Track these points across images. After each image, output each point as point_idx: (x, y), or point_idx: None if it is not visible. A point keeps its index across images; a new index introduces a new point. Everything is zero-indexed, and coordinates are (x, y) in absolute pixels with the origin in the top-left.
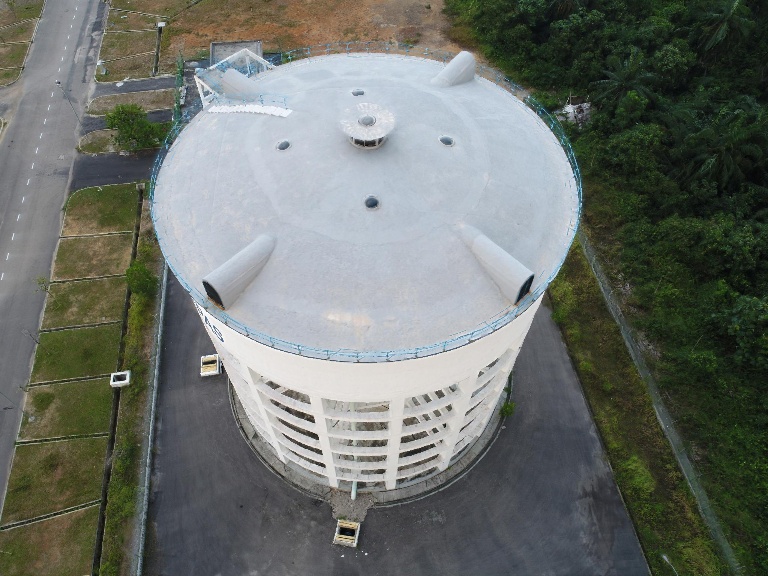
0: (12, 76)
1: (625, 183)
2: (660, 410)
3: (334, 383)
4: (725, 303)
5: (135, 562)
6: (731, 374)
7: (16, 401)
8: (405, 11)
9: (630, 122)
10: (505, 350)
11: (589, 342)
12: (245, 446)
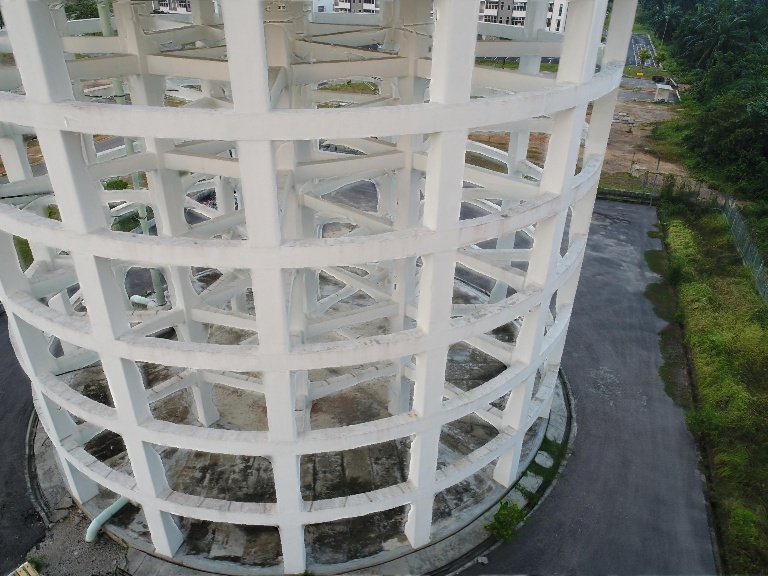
0: None
1: None
2: None
3: None
4: None
5: None
6: None
7: None
8: None
9: None
10: None
11: (767, 498)
12: None
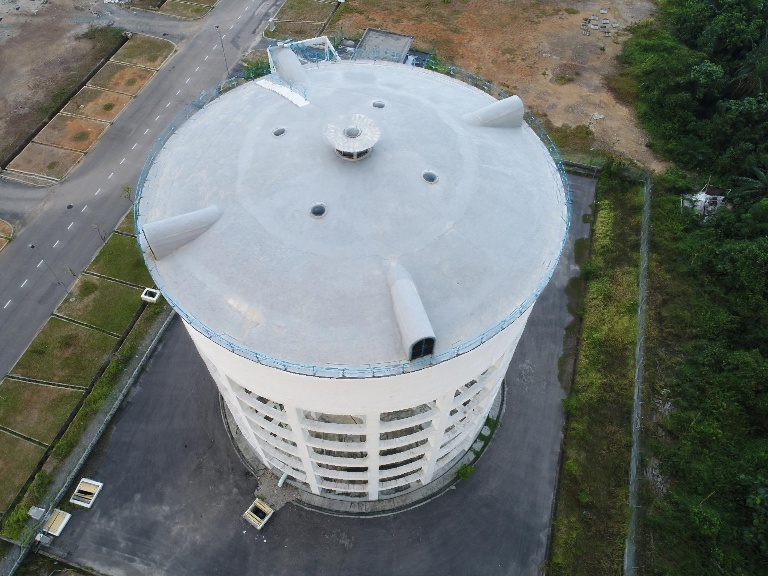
0: (201, 12)
1: (722, 296)
2: (633, 549)
3: (229, 364)
4: (767, 469)
5: (84, 451)
6: (736, 549)
7: (70, 280)
8: (576, 47)
9: (758, 232)
10: (415, 405)
11: (591, 444)
12: (216, 396)
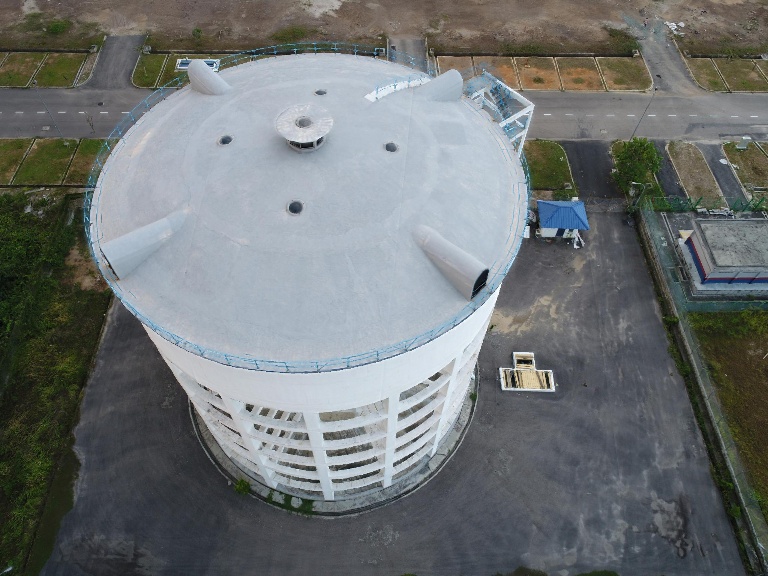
0: (714, 87)
1: None
2: None
3: None
4: None
5: None
6: None
7: None
8: None
9: None
10: None
11: None
12: None
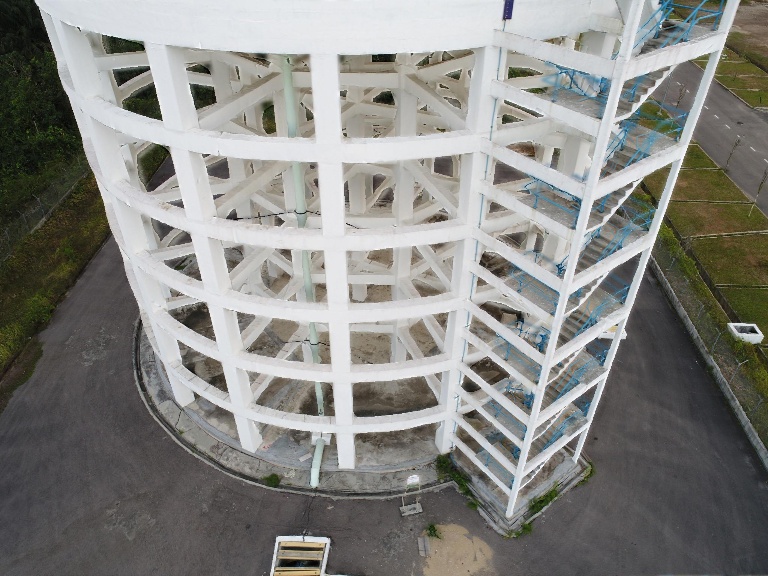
0: None
1: None
2: None
3: None
4: None
5: None
6: None
7: None
8: None
9: None
10: None
11: None
12: None
